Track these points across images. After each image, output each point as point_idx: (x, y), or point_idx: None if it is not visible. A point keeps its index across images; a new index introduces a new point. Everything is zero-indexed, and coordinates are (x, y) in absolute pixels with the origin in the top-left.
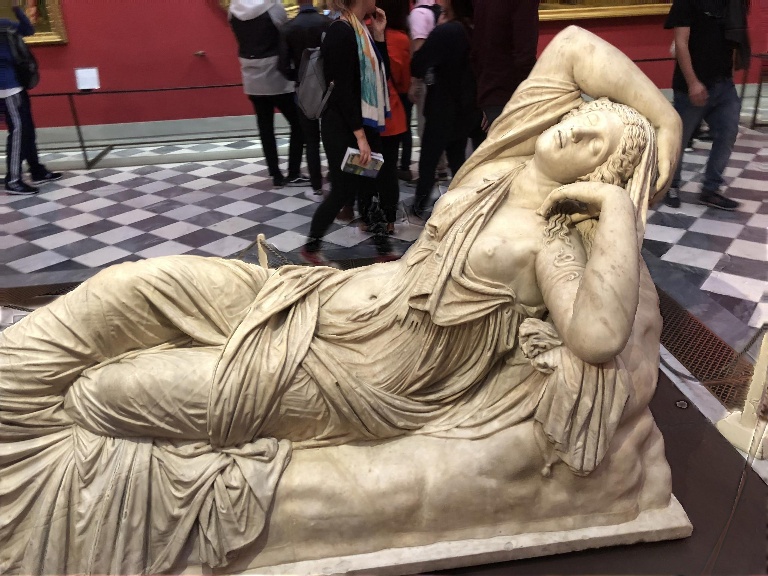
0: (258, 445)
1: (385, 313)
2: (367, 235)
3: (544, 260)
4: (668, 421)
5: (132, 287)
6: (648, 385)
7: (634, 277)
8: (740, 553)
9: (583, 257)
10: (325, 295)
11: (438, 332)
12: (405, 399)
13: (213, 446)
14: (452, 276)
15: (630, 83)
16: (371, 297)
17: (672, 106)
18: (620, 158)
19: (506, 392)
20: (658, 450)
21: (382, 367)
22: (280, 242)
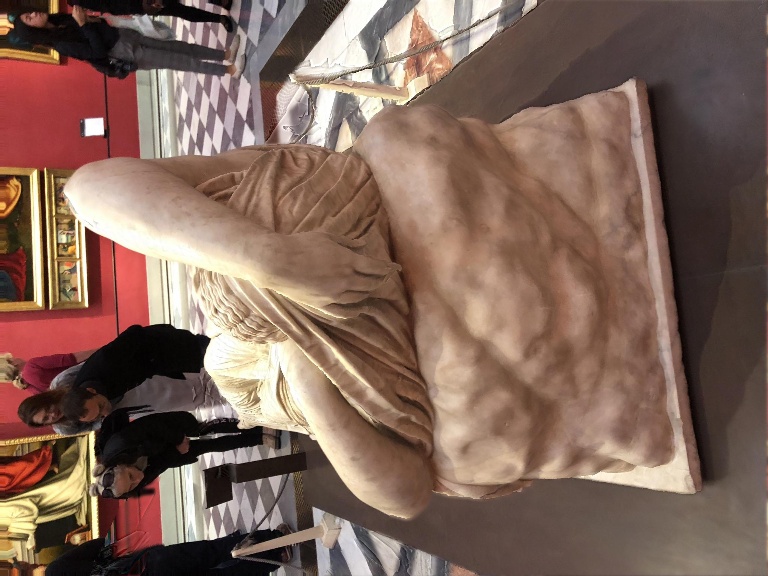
0: None
1: None
2: None
3: None
4: (767, 252)
5: (218, 375)
6: (505, 477)
7: (367, 487)
8: (764, 517)
9: None
10: None
11: None
12: None
13: None
14: None
15: None
16: None
17: (238, 264)
18: None
19: None
20: (609, 449)
21: None
22: None
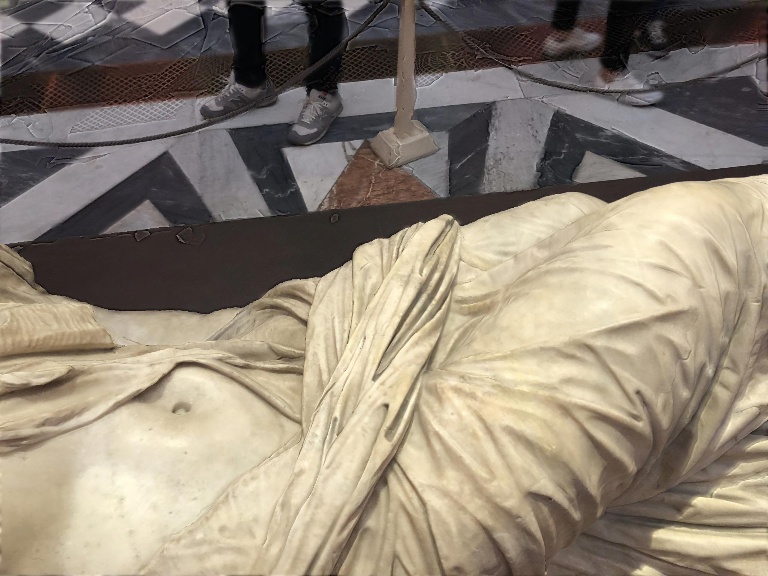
0: None
1: None
2: None
3: None
4: None
5: None
6: None
7: None
8: None
9: None
10: None
11: None
12: None
13: None
14: None
15: None
16: None
17: None
18: None
19: None
20: None
21: None
22: None
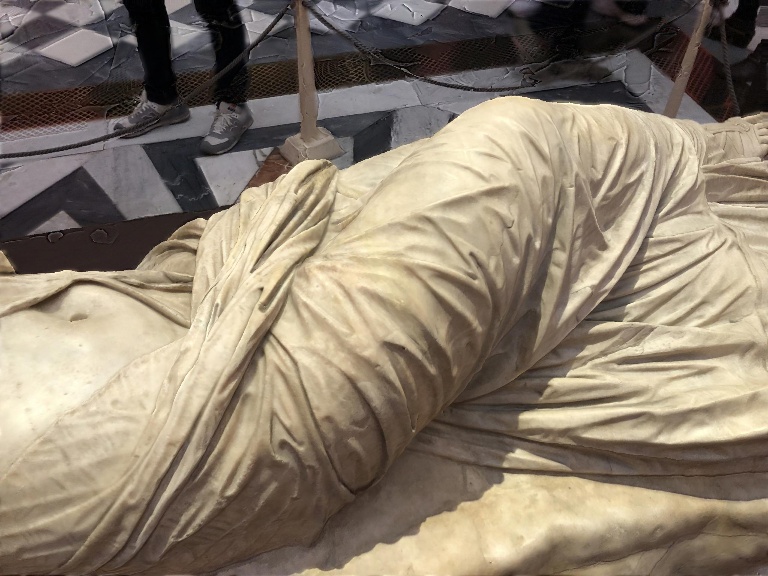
0: None
1: None
2: None
3: None
4: None
5: None
6: None
7: None
8: None
9: None
10: None
11: None
12: None
13: None
14: None
15: None
16: None
17: None
18: None
19: None
20: None
21: None
22: None
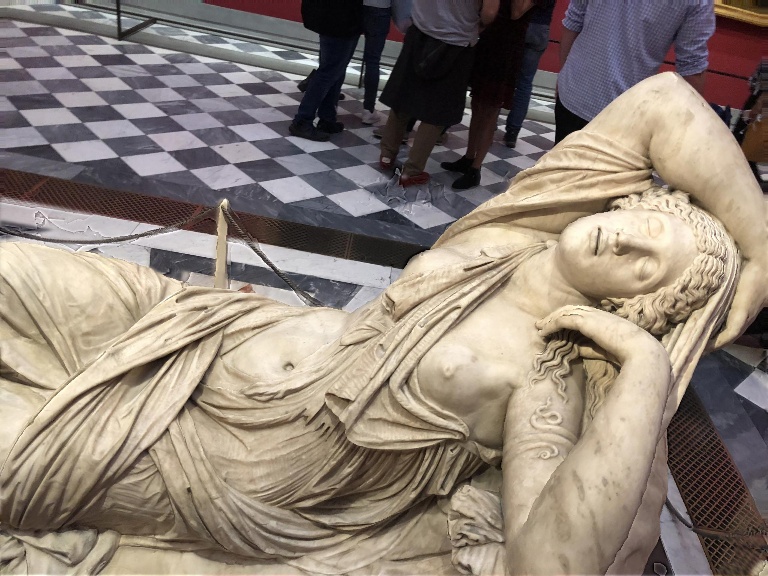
0: (63, 540)
1: (292, 399)
2: (381, 207)
3: (520, 406)
4: None
5: None
6: None
7: (632, 504)
8: None
9: (576, 417)
10: (233, 340)
11: (352, 448)
12: (288, 515)
13: (3, 526)
14: (389, 385)
15: (728, 185)
16: (287, 364)
17: None
18: (675, 297)
19: (418, 555)
20: None
21: (266, 471)
22: (283, 188)
